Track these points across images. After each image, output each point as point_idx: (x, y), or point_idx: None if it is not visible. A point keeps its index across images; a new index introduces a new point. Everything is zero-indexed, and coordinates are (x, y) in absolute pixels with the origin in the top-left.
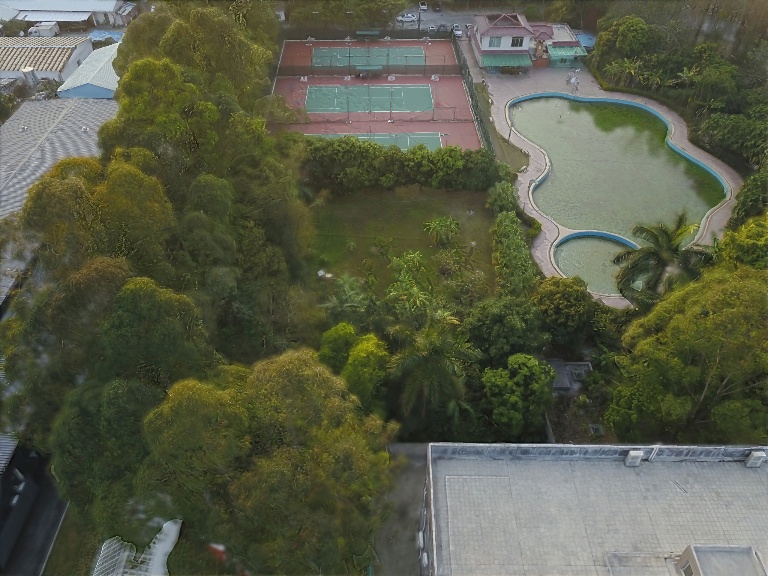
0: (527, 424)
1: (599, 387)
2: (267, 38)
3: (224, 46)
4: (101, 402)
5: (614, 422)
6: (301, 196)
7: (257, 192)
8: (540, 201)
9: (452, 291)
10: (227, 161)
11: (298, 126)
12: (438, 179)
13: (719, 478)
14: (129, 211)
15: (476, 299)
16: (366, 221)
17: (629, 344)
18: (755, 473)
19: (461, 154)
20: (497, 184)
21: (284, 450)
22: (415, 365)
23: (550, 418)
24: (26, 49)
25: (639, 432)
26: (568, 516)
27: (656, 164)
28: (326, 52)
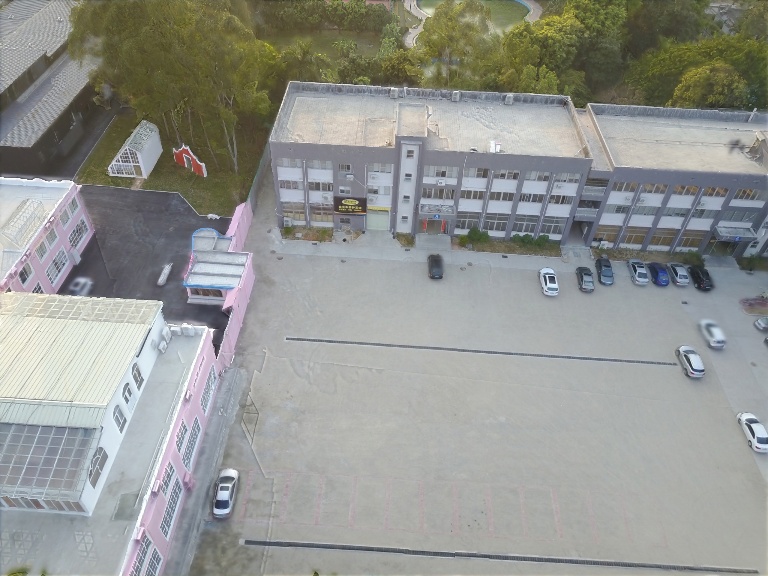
0: None
1: None
2: None
3: None
4: (126, 2)
5: None
6: None
7: None
8: None
9: None
10: None
11: None
12: (348, 20)
13: (436, 104)
14: None
15: None
16: None
17: None
18: (455, 103)
19: (365, 5)
20: (387, 24)
21: None
22: (294, 65)
23: None
24: None
25: None
26: (353, 109)
27: None
28: None
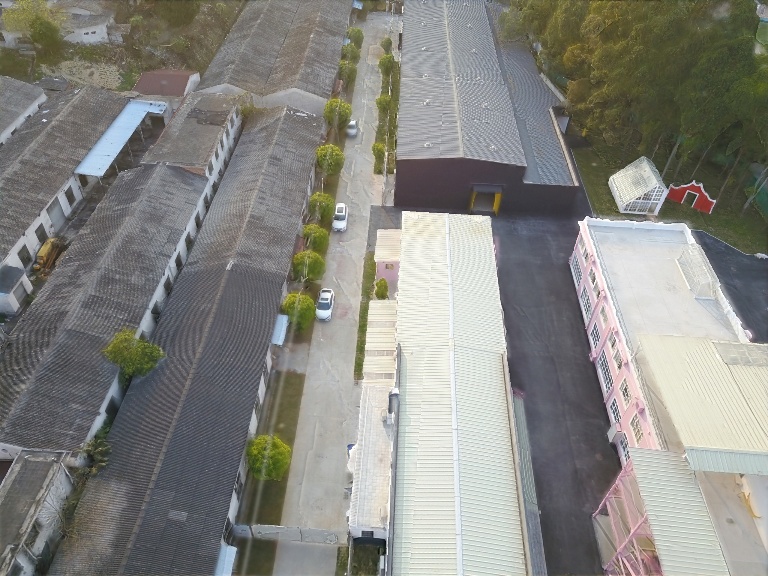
0: None
1: None
2: None
3: None
4: (740, 44)
5: None
6: None
7: None
8: None
9: None
10: None
11: None
12: None
13: None
14: None
15: None
16: None
17: None
18: None
19: None
20: None
21: None
22: None
23: None
24: None
25: None
26: None
27: None
28: None
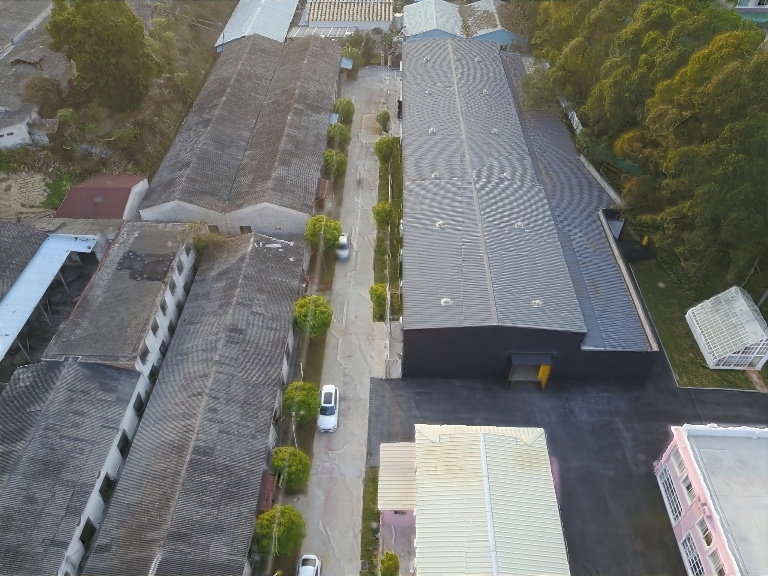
0: None
1: None
2: None
3: None
4: None
5: None
6: None
7: None
8: None
9: None
10: None
11: None
12: None
13: None
14: None
15: None
16: None
17: None
18: None
19: None
20: None
21: None
22: None
23: None
24: (354, 4)
25: None
26: None
27: None
28: None
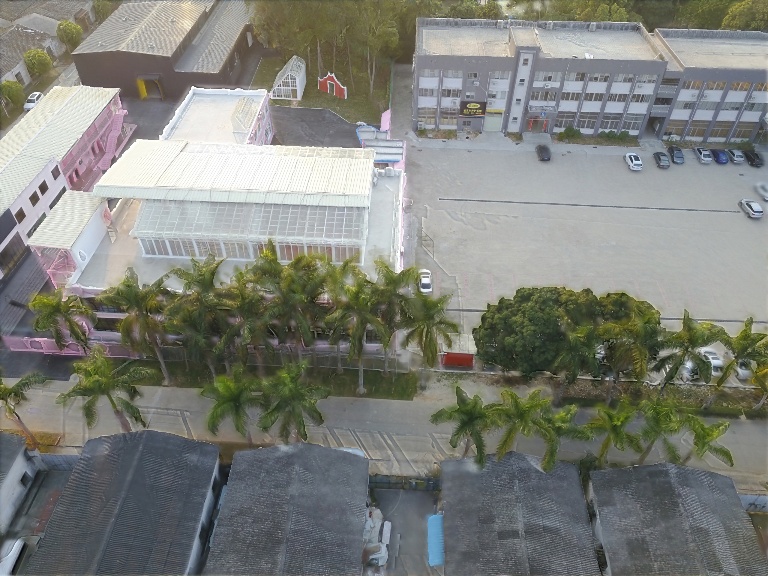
0: None
1: None
2: None
3: None
4: None
5: None
6: None
7: None
8: None
9: None
10: None
11: None
12: None
13: None
14: None
15: None
16: None
17: None
18: (549, 31)
19: None
20: None
21: None
22: (413, 9)
23: None
24: None
25: None
26: (470, 36)
27: None
28: None
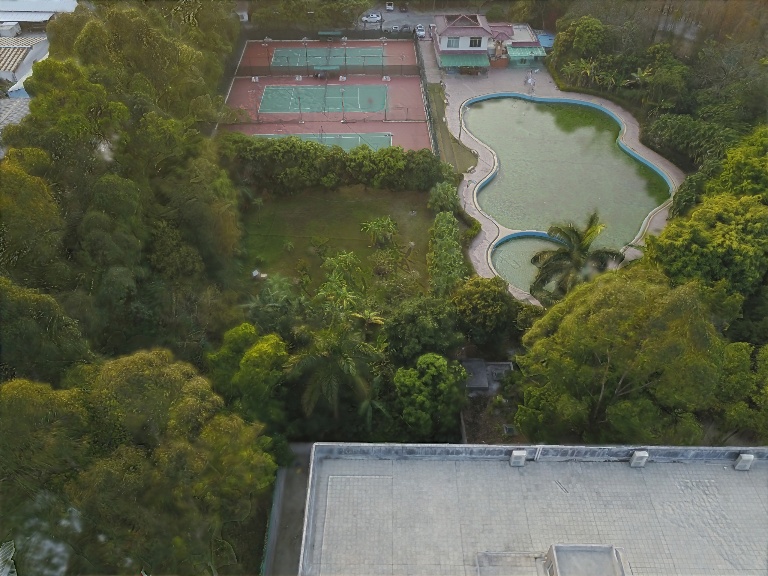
0: (437, 424)
1: (515, 387)
2: (225, 38)
3: (142, 46)
4: None
5: (521, 422)
6: (240, 196)
7: (182, 192)
8: (485, 201)
9: (383, 291)
10: (143, 161)
11: (251, 126)
12: (380, 179)
13: (602, 478)
14: (10, 211)
15: (406, 299)
16: (307, 221)
17: (528, 344)
18: (639, 473)
19: (403, 154)
20: (438, 184)
21: (122, 449)
22: (316, 365)
23: (465, 418)
24: None
25: (546, 432)
26: (445, 516)
27: (605, 164)
28: (287, 52)
